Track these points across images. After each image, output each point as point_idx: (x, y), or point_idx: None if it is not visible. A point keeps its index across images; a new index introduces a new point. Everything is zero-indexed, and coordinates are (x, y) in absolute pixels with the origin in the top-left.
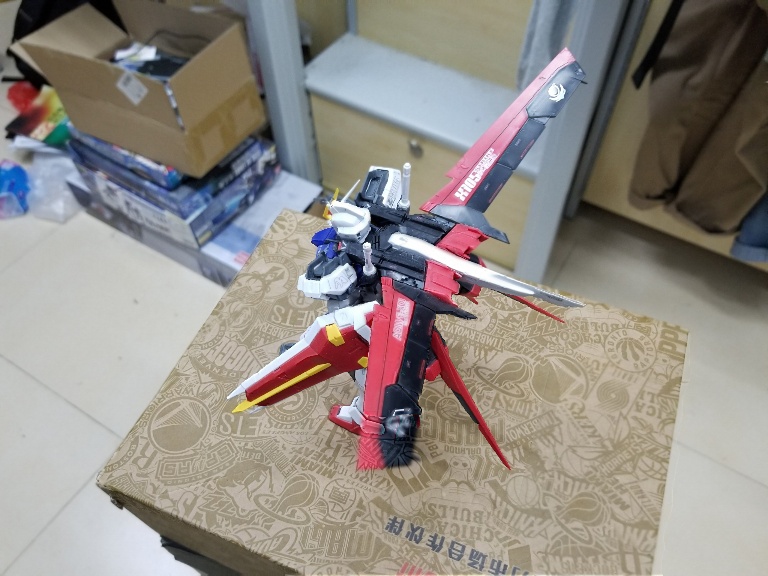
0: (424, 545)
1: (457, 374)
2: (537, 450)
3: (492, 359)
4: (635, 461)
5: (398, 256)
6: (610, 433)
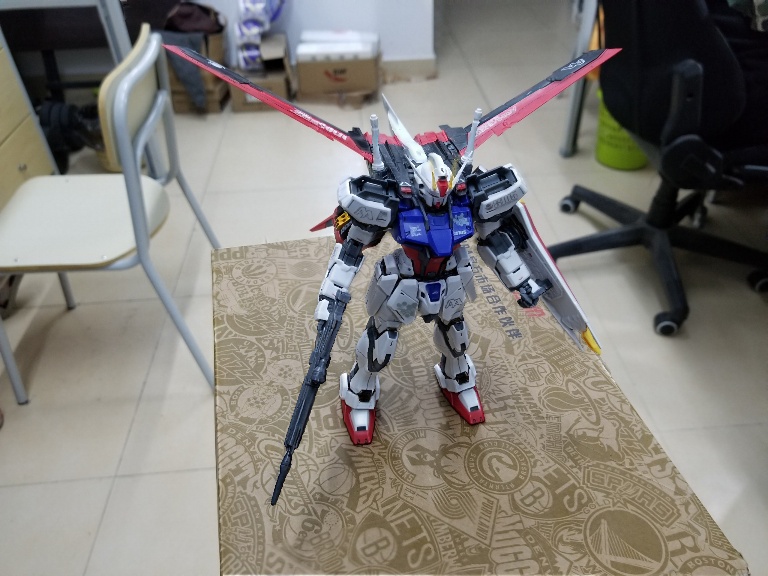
0: (508, 314)
1: None
2: None
3: None
4: None
5: None
6: None
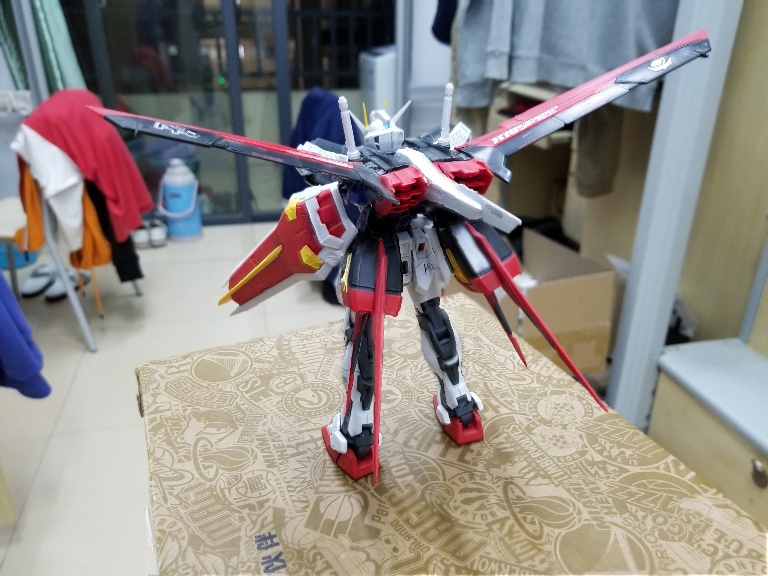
0: None
1: (382, 315)
2: None
3: (537, 485)
4: None
5: (389, 156)
6: None
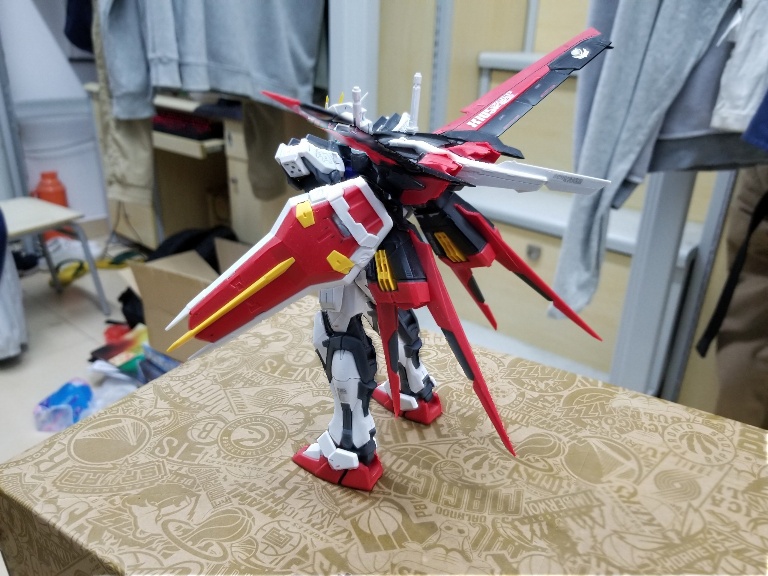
0: None
1: (449, 301)
2: (567, 529)
3: (514, 432)
4: (716, 560)
5: None
6: (675, 524)
